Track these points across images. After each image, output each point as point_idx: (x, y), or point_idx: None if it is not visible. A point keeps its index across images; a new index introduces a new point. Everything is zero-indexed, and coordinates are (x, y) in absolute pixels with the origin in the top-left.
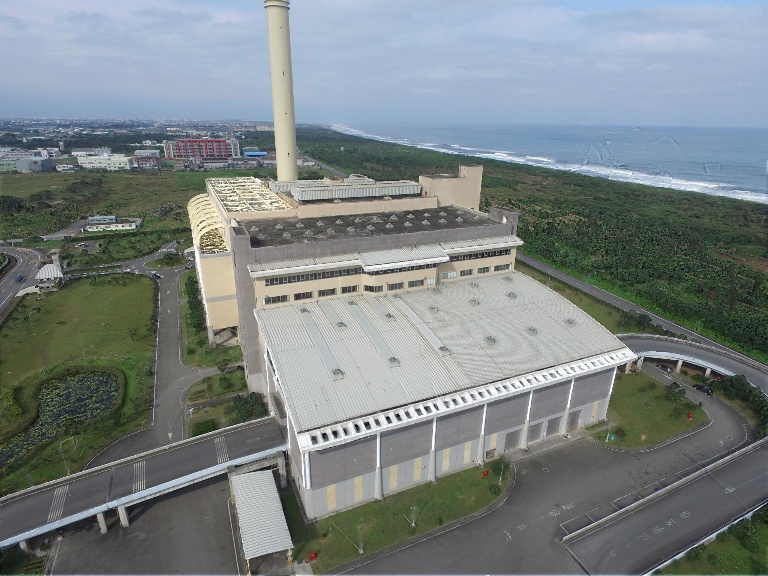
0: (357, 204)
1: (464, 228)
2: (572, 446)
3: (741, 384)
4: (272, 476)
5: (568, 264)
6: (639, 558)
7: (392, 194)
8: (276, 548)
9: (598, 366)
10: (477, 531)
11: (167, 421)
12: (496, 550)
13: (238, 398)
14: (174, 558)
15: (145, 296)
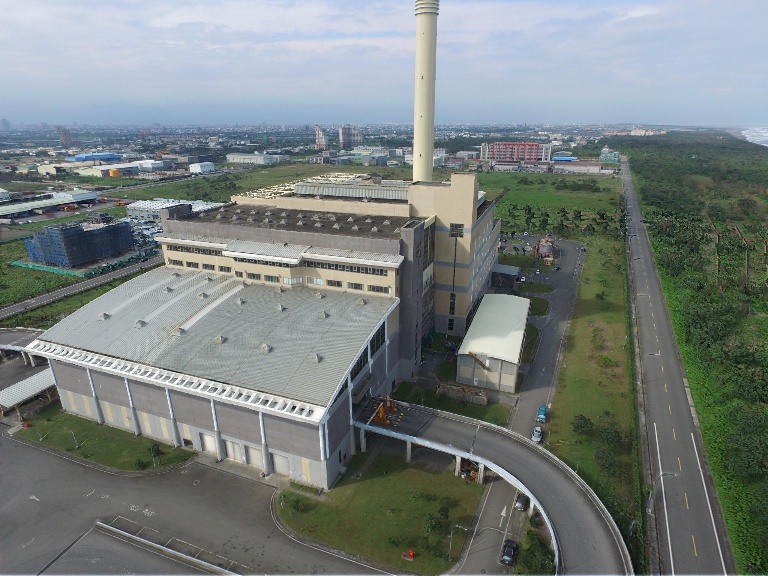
0: (325, 202)
1: (338, 236)
2: (251, 485)
3: (536, 574)
4: None
5: (695, 340)
6: None
7: (378, 197)
8: (2, 402)
9: (263, 406)
10: (87, 477)
11: None
12: (69, 493)
13: None
14: None
15: None
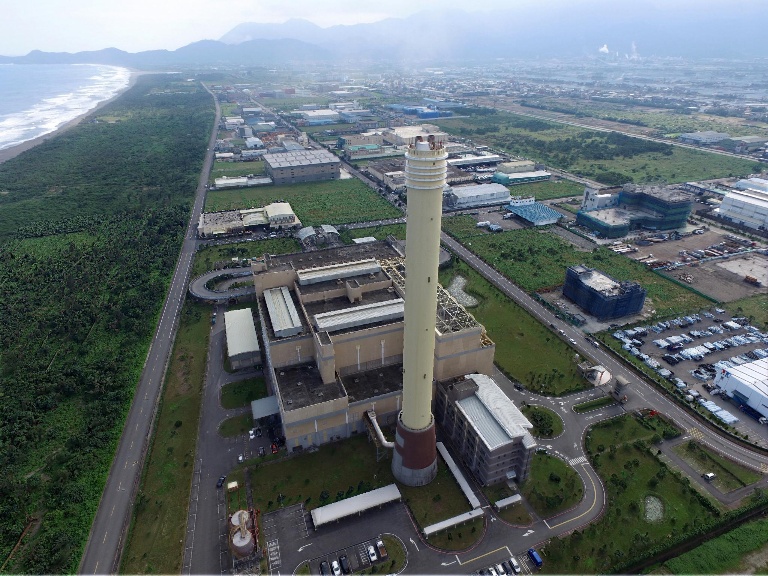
0: None
1: (297, 253)
2: None
3: None
4: None
5: None
6: None
7: None
8: None
9: None
10: None
11: None
12: None
13: None
14: None
15: (499, 359)
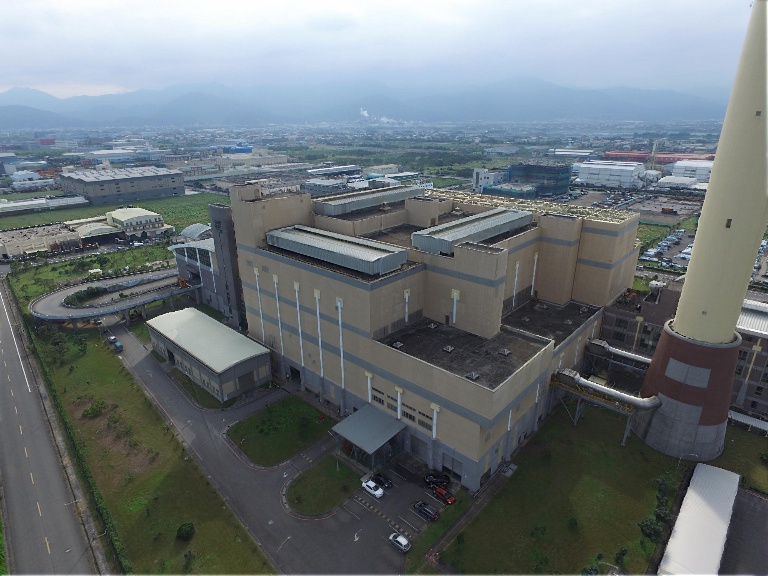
0: None
1: None
2: None
3: None
4: None
5: None
6: None
7: None
8: None
9: None
10: None
11: None
12: None
13: None
14: None
15: None
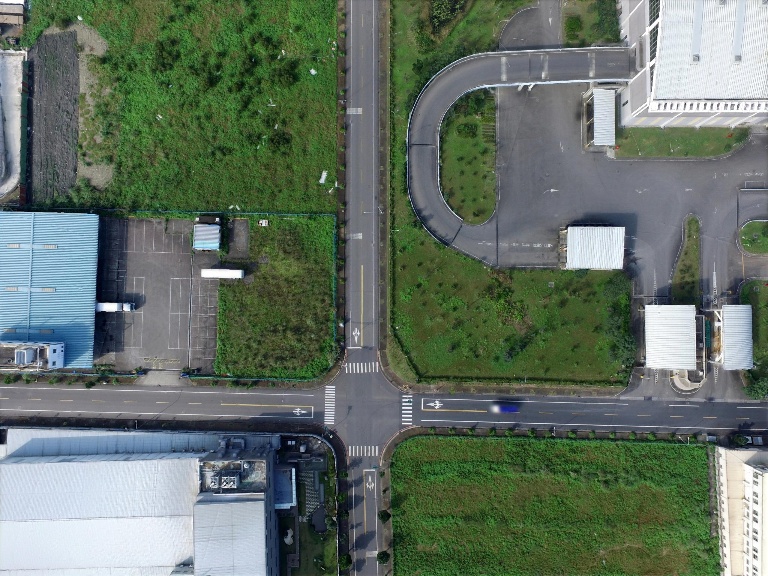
0: None
1: None
2: None
3: None
4: (614, 96)
5: None
6: None
7: None
8: (608, 144)
9: None
10: (702, 167)
11: (548, 4)
12: (704, 180)
13: (602, 3)
14: (553, 120)
15: None
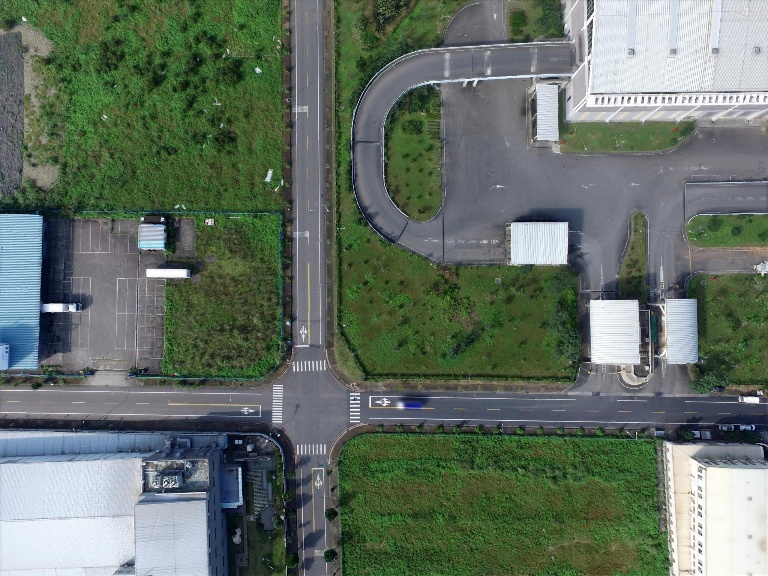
0: None
1: None
2: (746, 130)
3: None
4: (557, 91)
5: None
6: (715, 206)
7: None
8: (551, 139)
9: None
10: (647, 161)
11: None
12: (650, 175)
13: None
14: (498, 116)
15: None
